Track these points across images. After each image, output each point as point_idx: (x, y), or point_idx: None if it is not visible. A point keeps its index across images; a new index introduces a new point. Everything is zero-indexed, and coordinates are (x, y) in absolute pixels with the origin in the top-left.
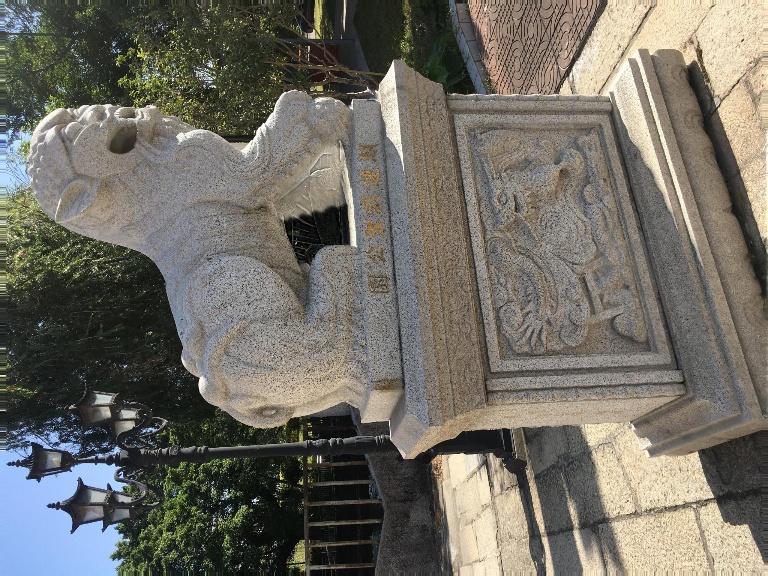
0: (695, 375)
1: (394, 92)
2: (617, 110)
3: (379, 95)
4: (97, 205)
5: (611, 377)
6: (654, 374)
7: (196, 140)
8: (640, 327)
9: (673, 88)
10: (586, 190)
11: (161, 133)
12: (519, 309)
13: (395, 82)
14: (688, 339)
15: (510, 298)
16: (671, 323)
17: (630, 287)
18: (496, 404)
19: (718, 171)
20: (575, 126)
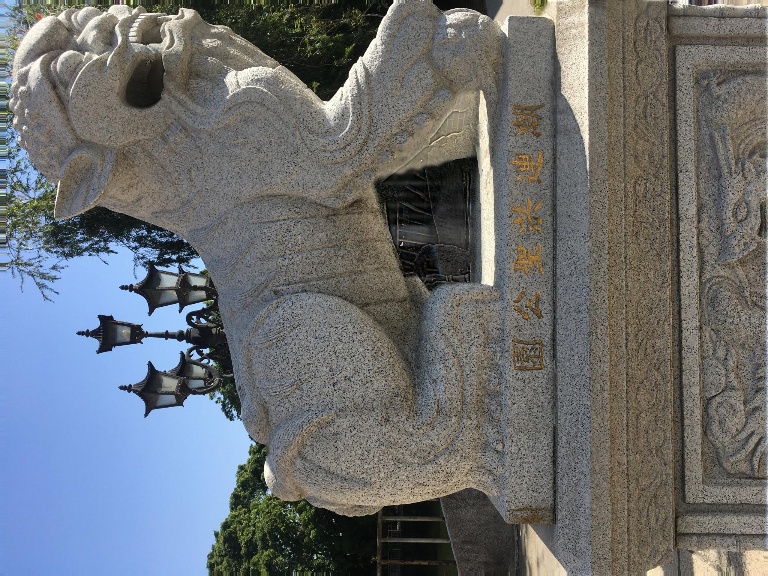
0: None
1: (583, 10)
2: None
3: (554, 8)
4: (114, 187)
5: None
6: None
7: (254, 92)
8: None
9: None
10: None
11: (201, 72)
12: (742, 404)
13: None
14: None
15: (729, 383)
16: None
17: None
18: None
19: None
20: None
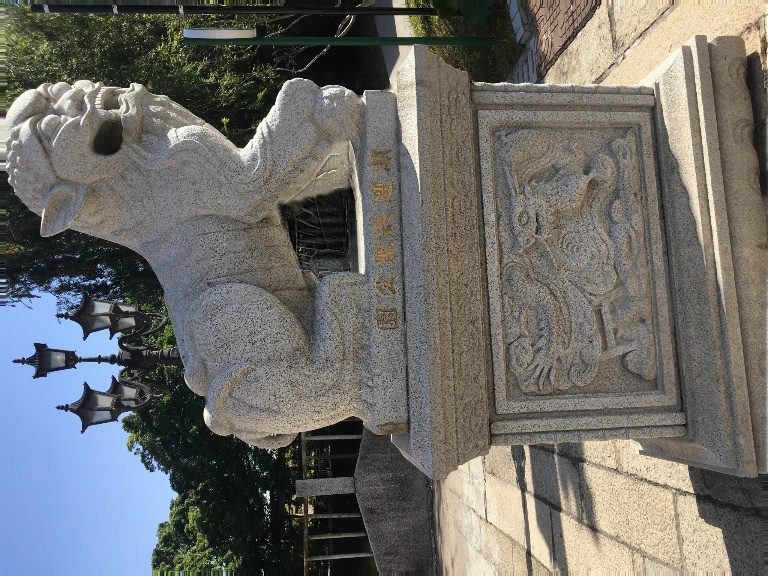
0: (698, 421)
1: (413, 88)
2: (660, 107)
3: (395, 86)
4: (84, 212)
5: (615, 420)
6: (658, 417)
7: (190, 144)
8: (650, 366)
9: (727, 90)
10: (614, 206)
11: (150, 129)
12: (530, 346)
13: (415, 75)
14: (697, 384)
15: (522, 333)
16: (682, 363)
17: (646, 321)
18: None
19: (760, 197)
20: (611, 125)
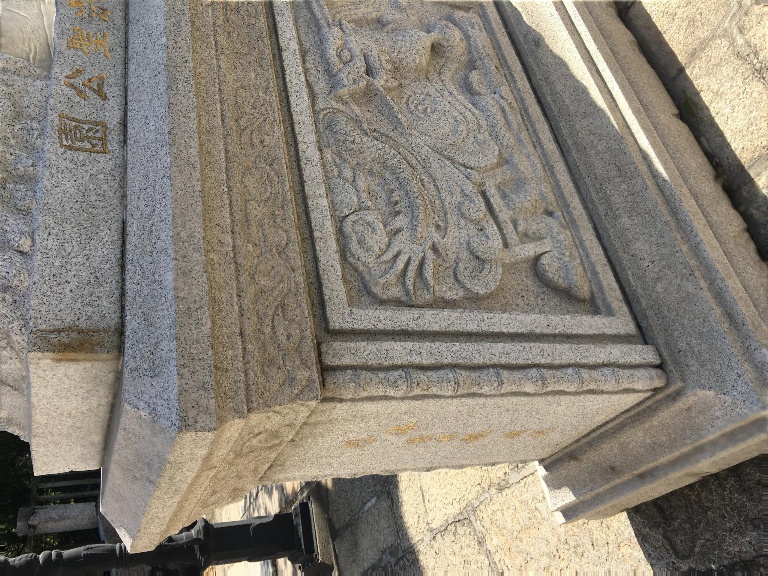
0: (682, 350)
1: None
2: None
3: None
4: None
5: (552, 350)
6: (617, 349)
7: None
8: (581, 274)
9: None
10: (472, 75)
11: None
12: (380, 222)
13: None
14: (660, 292)
15: (362, 203)
16: (625, 270)
17: (556, 213)
18: (340, 398)
19: (653, 69)
20: None
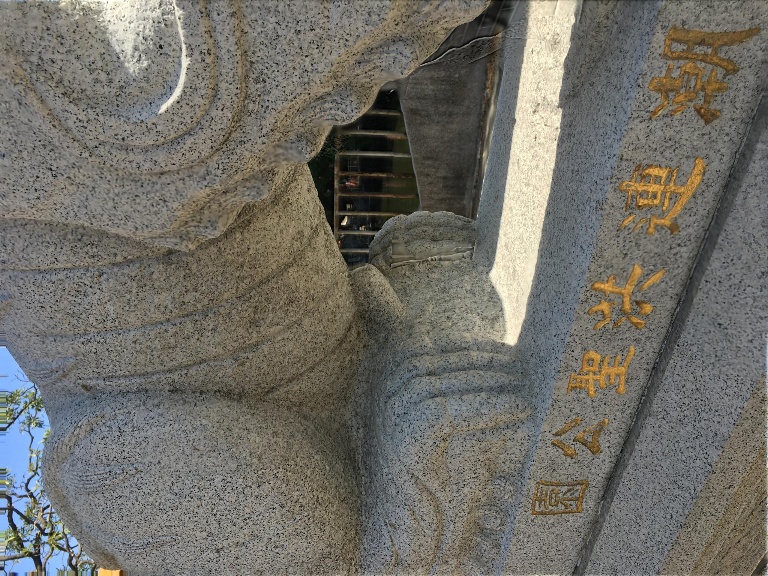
0: None
1: None
2: None
3: None
4: None
5: None
6: None
7: None
8: None
9: None
10: None
11: None
12: None
13: None
14: None
15: None
16: None
17: None
18: None
19: None
20: None
